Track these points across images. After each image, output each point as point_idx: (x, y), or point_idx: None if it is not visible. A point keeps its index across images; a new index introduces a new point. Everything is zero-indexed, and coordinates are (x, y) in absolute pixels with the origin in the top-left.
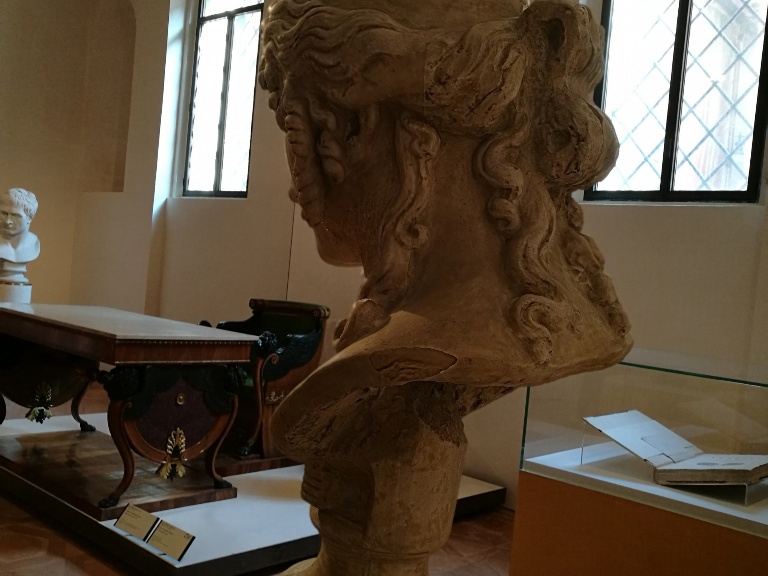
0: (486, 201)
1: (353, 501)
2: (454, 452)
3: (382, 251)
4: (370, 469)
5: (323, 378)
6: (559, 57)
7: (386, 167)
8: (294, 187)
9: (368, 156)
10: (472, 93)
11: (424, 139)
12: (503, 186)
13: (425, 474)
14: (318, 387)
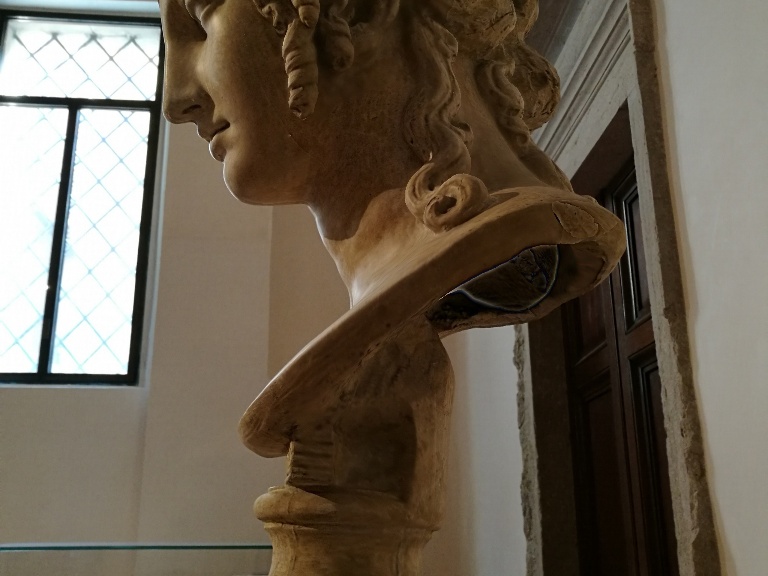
0: (496, 119)
1: (363, 471)
2: None
3: (444, 136)
4: (408, 412)
5: (486, 237)
6: (524, 13)
7: (395, 65)
8: (235, 81)
9: (377, 49)
10: (493, 9)
11: (447, 41)
12: (514, 106)
13: None
14: (474, 251)
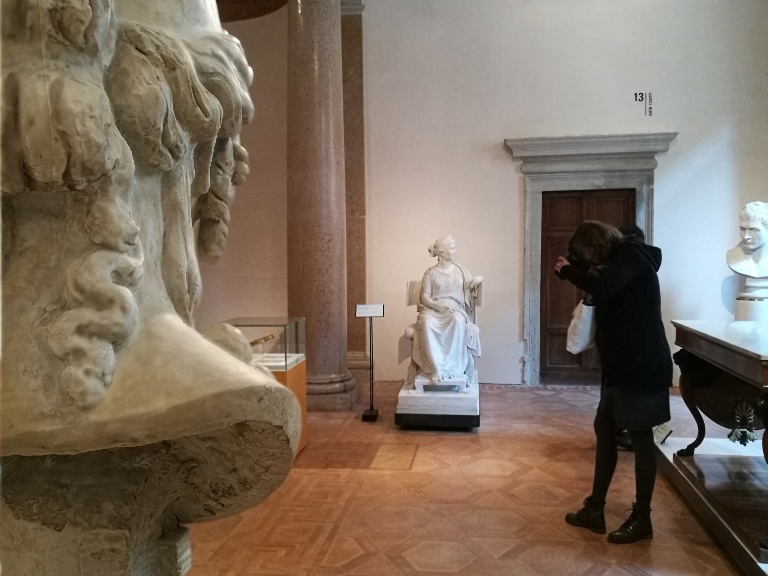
0: None
1: None
2: (48, 536)
3: None
4: None
5: None
6: None
7: None
8: None
9: None
10: None
11: None
12: None
13: (12, 555)
14: None
